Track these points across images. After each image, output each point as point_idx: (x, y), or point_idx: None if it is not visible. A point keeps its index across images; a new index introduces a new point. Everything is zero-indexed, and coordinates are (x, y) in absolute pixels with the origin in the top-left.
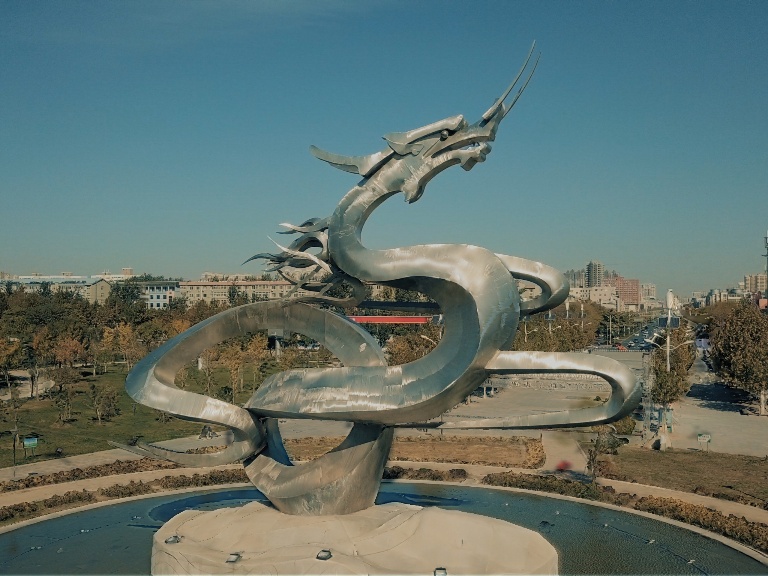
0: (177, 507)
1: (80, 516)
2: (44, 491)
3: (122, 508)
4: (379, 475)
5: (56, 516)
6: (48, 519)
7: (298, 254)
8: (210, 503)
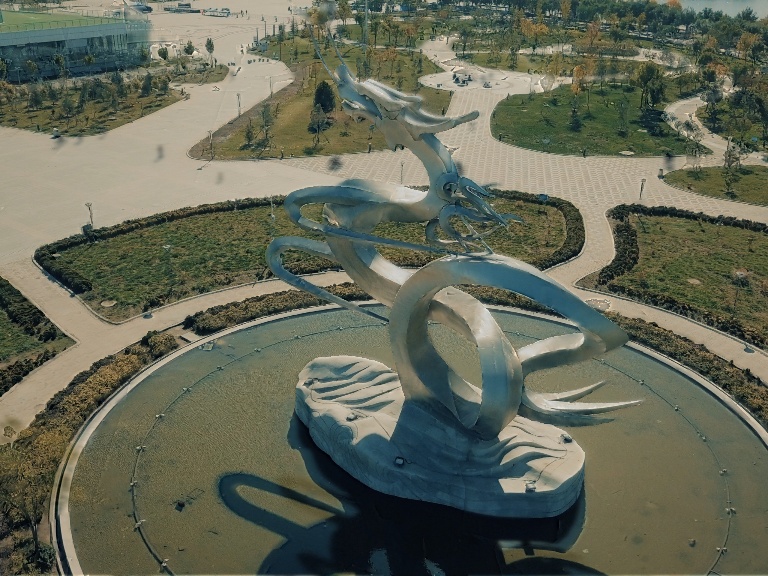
0: None
1: None
2: None
3: None
4: None
5: None
6: None
7: None
8: None
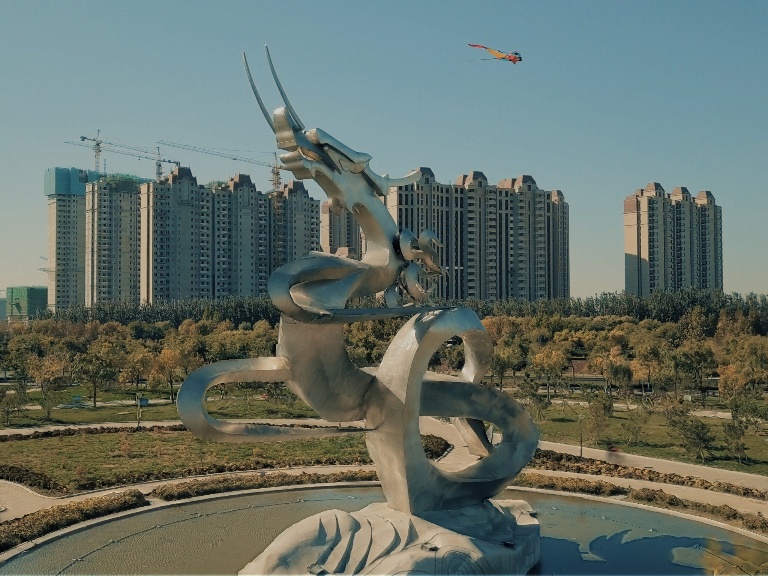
0: (708, 544)
1: (664, 518)
2: (762, 507)
3: (699, 528)
4: (400, 482)
5: (652, 509)
6: (643, 508)
7: None
8: (733, 556)
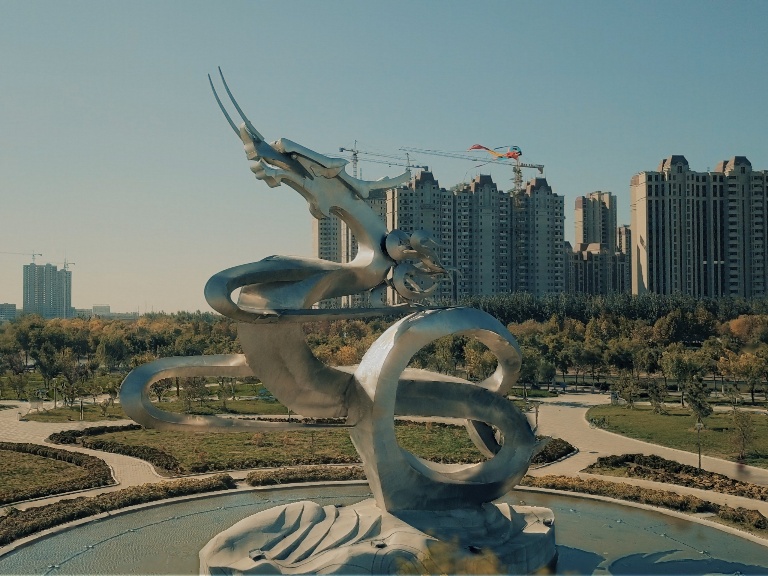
0: (755, 573)
1: (736, 540)
2: None
3: (764, 555)
4: None
5: None
6: (719, 529)
7: None
8: None
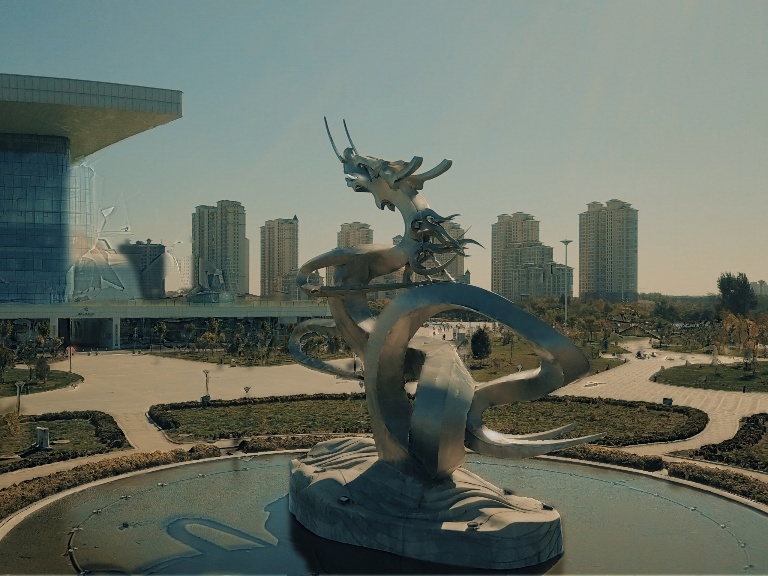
0: None
1: None
2: None
3: None
4: None
5: None
6: None
7: None
8: None
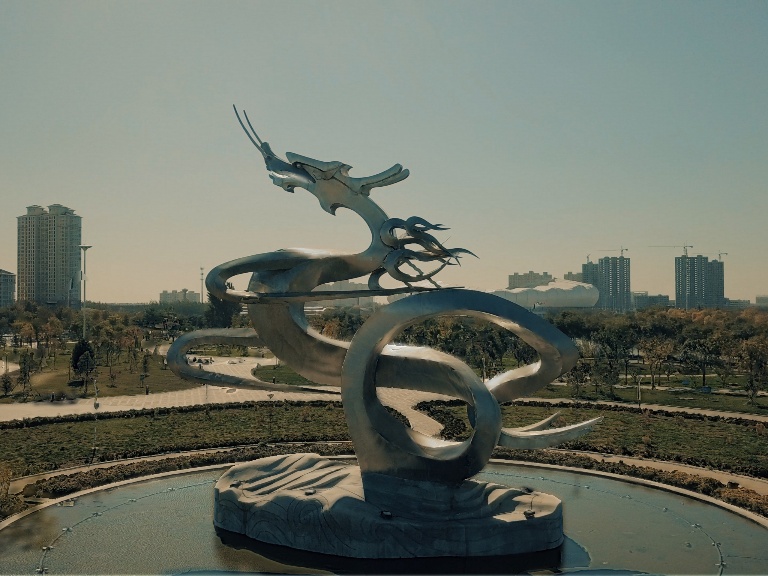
0: None
1: None
2: None
3: None
4: None
5: None
6: None
7: (423, 251)
8: None
